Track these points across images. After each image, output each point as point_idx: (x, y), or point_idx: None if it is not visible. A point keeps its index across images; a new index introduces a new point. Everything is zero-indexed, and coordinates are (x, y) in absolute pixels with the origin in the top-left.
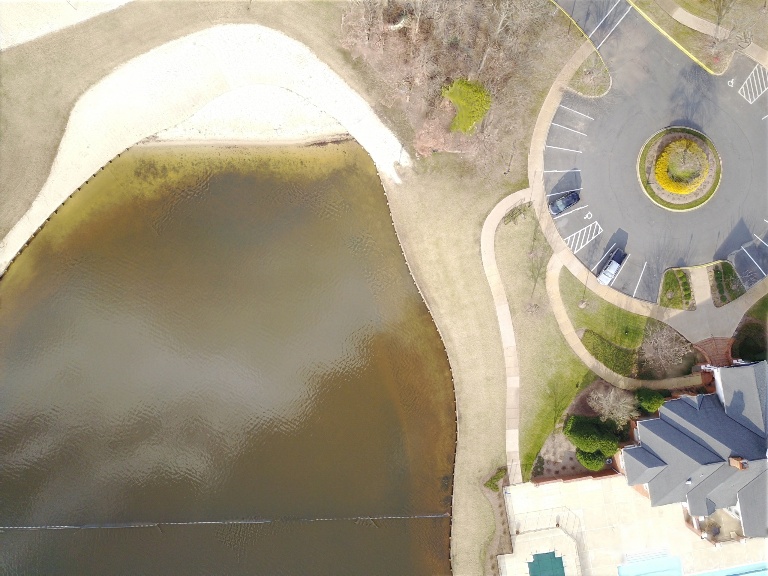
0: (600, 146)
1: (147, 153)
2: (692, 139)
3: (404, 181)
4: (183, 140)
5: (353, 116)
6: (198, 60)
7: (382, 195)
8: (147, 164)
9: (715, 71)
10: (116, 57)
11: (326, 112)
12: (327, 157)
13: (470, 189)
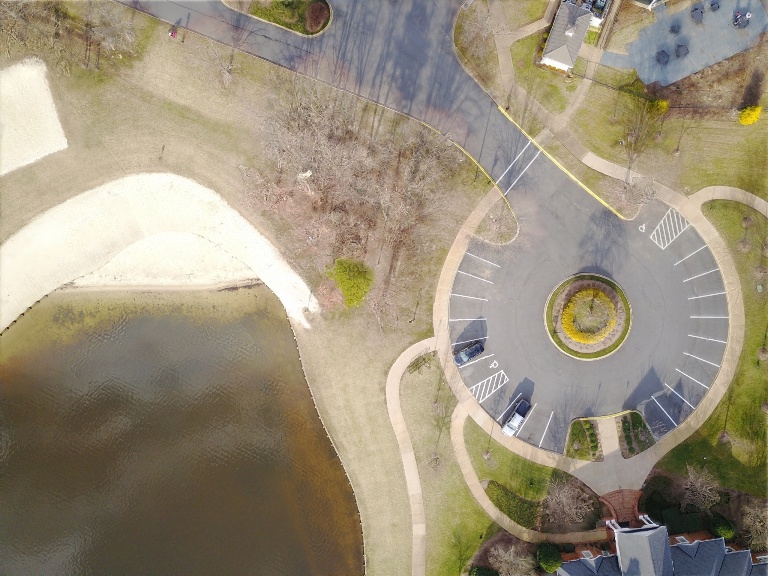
0: (507, 294)
1: (65, 299)
2: (601, 287)
3: (313, 326)
4: (99, 286)
5: (263, 262)
6: (113, 209)
7: (292, 339)
8: (65, 309)
9: (626, 216)
10: (34, 208)
11: (237, 258)
12: (239, 301)
13: (376, 337)
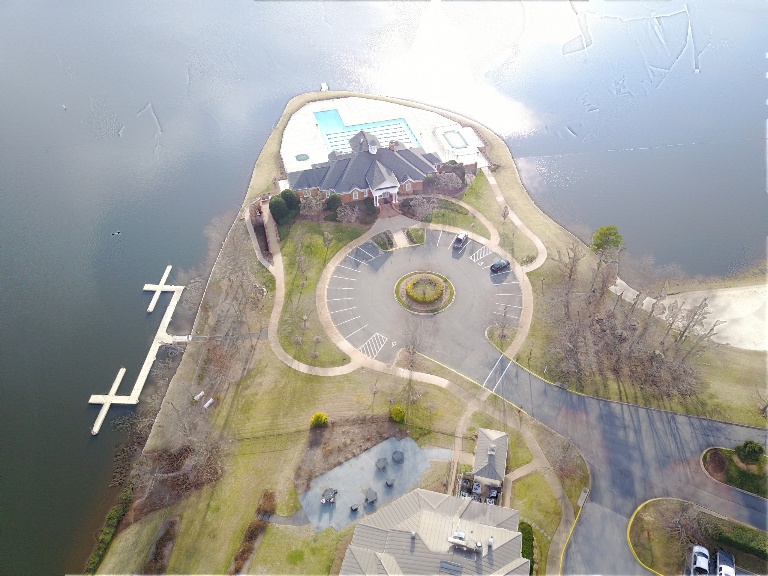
0: (484, 298)
1: None
2: (419, 307)
3: None
4: (763, 287)
5: None
6: None
7: None
8: None
9: None
10: None
11: None
12: None
13: None
